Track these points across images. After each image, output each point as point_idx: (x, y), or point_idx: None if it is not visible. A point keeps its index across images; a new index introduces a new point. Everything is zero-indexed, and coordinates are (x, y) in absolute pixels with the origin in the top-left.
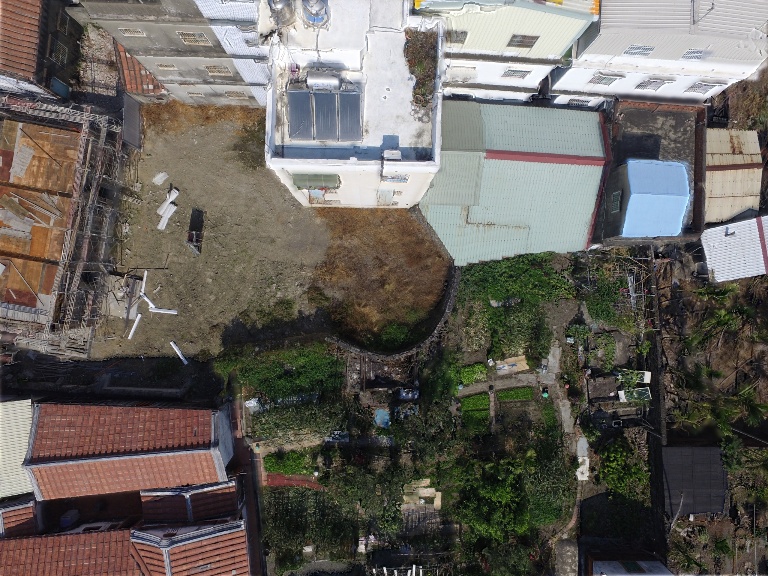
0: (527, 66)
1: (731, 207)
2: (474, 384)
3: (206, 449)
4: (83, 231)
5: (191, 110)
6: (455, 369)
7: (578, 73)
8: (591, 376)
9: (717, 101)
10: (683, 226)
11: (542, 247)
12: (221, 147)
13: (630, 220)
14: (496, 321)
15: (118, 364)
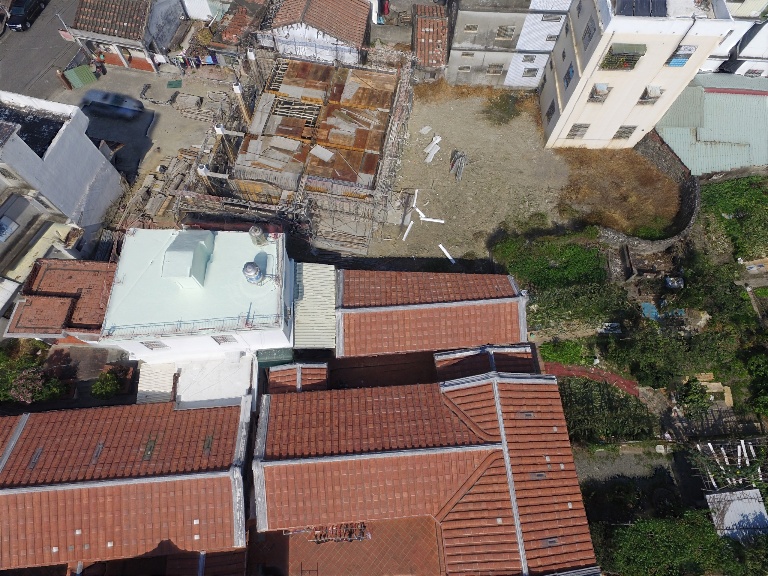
0: None
1: None
2: None
3: (515, 297)
4: None
5: (449, 89)
6: None
7: (767, 31)
8: None
9: None
10: None
11: (763, 160)
12: (472, 112)
13: None
14: (733, 229)
15: (391, 262)
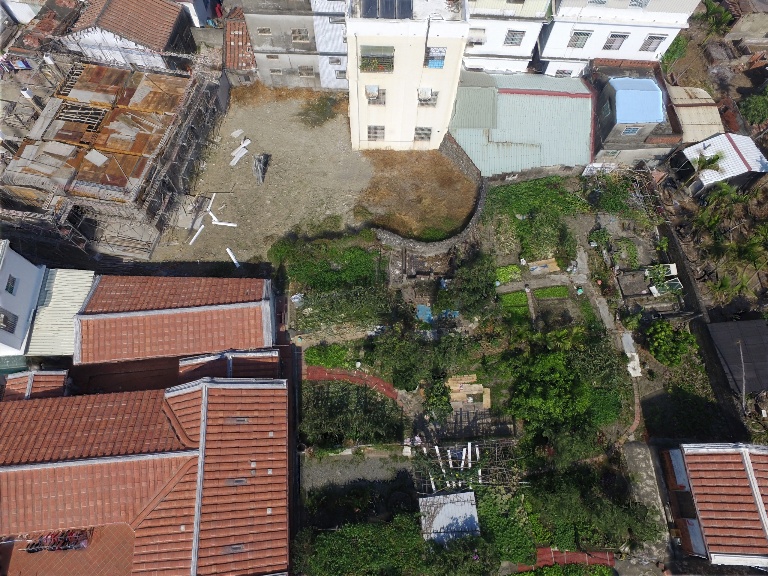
0: (522, 26)
1: (702, 131)
2: (510, 283)
3: (257, 301)
4: (176, 141)
5: (268, 92)
6: (491, 269)
7: (559, 32)
8: (620, 270)
9: (666, 58)
10: (666, 133)
11: (554, 160)
12: (288, 114)
13: (620, 109)
14: (523, 229)
15: (175, 267)
